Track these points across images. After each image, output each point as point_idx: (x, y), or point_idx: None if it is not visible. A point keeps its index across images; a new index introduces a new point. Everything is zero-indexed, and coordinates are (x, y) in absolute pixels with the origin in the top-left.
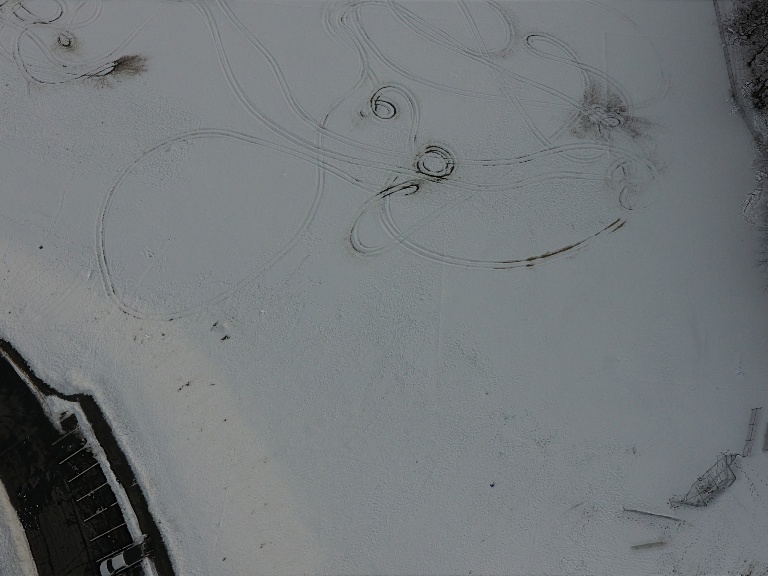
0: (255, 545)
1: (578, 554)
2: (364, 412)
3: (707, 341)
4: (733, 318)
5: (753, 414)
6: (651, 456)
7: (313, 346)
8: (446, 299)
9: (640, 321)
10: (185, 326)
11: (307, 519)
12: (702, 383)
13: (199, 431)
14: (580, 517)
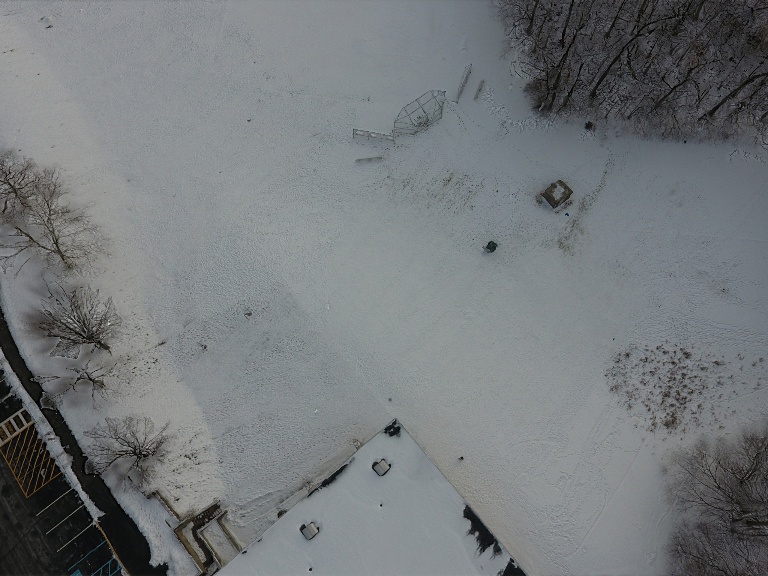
0: (47, 145)
1: (312, 165)
2: (153, 74)
3: (440, 28)
4: (464, 12)
5: (466, 70)
6: (382, 103)
7: (119, 32)
8: (232, 2)
9: (388, 15)
10: (18, 19)
11: (95, 137)
12: (432, 55)
13: (15, 77)
14: (318, 142)
